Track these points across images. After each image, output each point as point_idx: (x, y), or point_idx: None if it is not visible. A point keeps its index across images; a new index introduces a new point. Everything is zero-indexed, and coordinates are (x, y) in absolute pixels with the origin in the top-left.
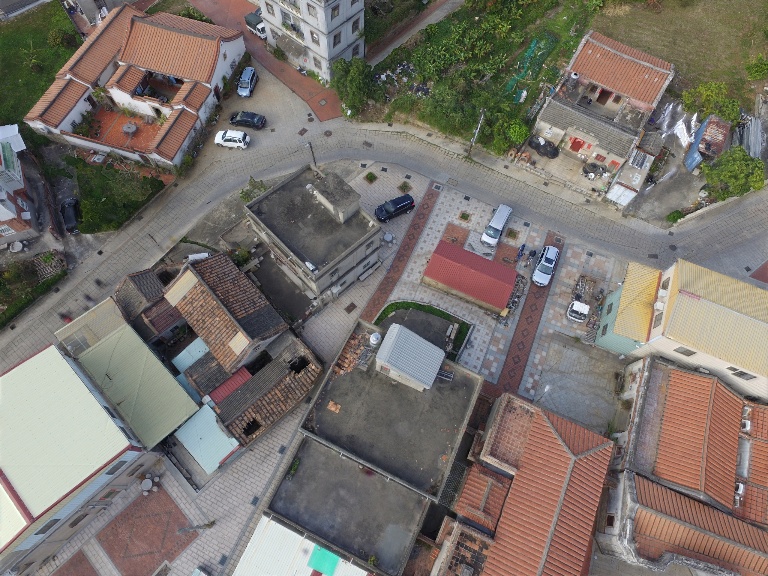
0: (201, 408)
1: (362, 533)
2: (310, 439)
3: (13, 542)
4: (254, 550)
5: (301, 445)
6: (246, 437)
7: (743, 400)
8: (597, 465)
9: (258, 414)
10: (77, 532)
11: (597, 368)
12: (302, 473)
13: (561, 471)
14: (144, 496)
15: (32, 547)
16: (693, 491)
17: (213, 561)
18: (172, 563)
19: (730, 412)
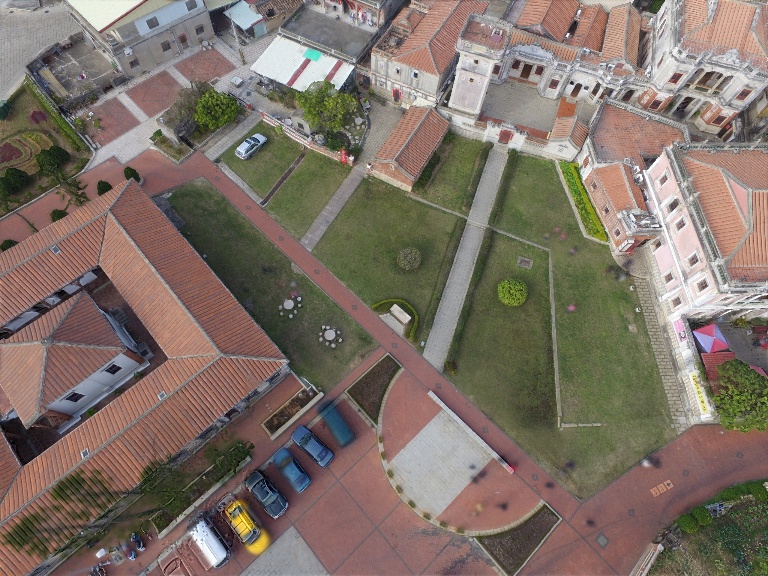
0: (240, 2)
1: (336, 44)
2: (307, 8)
3: (138, 7)
4: (271, 50)
5: (301, 9)
6: (268, 17)
7: (580, 4)
8: (477, 7)
9: (275, 6)
10: (163, 63)
11: (496, 9)
12: (301, 20)
13: (454, 3)
14: (203, 51)
15: (142, 38)
16: (535, 25)
17: (245, 78)
18: (220, 78)
19: (569, 4)
